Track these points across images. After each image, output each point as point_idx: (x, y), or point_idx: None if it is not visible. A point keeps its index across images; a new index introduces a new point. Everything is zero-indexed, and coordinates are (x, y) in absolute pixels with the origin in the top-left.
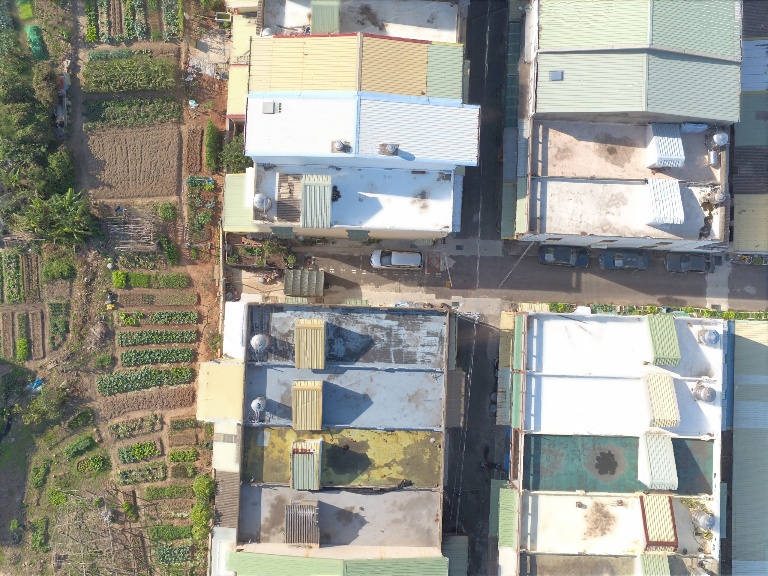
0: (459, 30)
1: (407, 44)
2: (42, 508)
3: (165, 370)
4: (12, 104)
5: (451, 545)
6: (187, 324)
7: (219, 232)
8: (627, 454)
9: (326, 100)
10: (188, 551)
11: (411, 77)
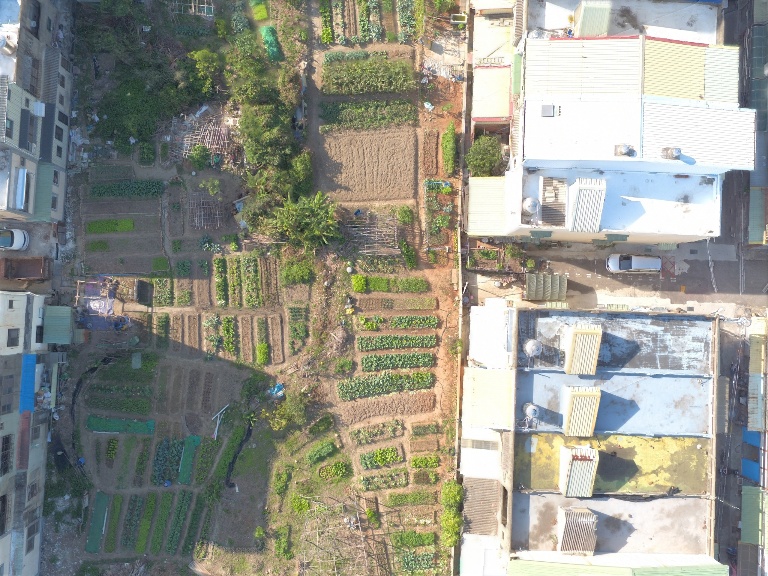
0: (723, 33)
1: (685, 47)
2: (284, 515)
3: (406, 375)
4: (258, 106)
5: None
6: (426, 329)
7: (457, 236)
8: None
9: (607, 103)
10: (432, 558)
11: (690, 80)
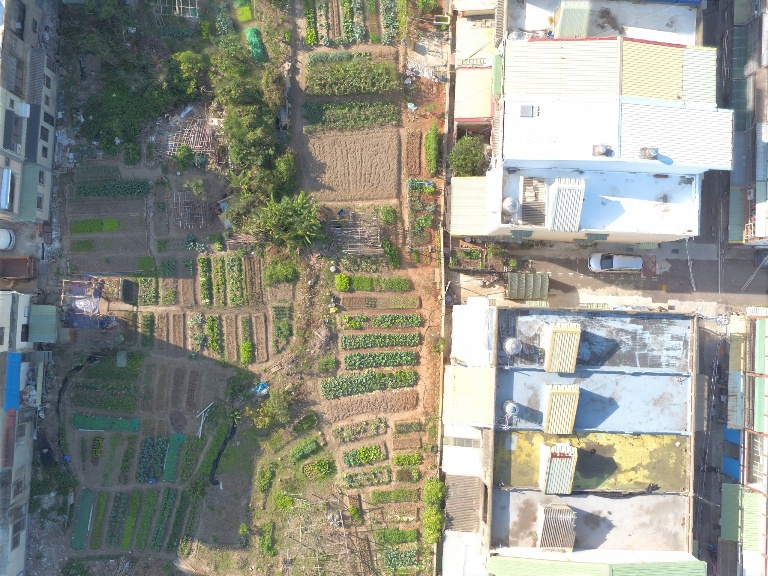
0: (702, 34)
1: (663, 48)
2: (268, 512)
3: (389, 373)
4: (242, 106)
5: None
6: (409, 327)
7: (439, 235)
8: None
9: (585, 104)
10: (414, 555)
11: (668, 81)
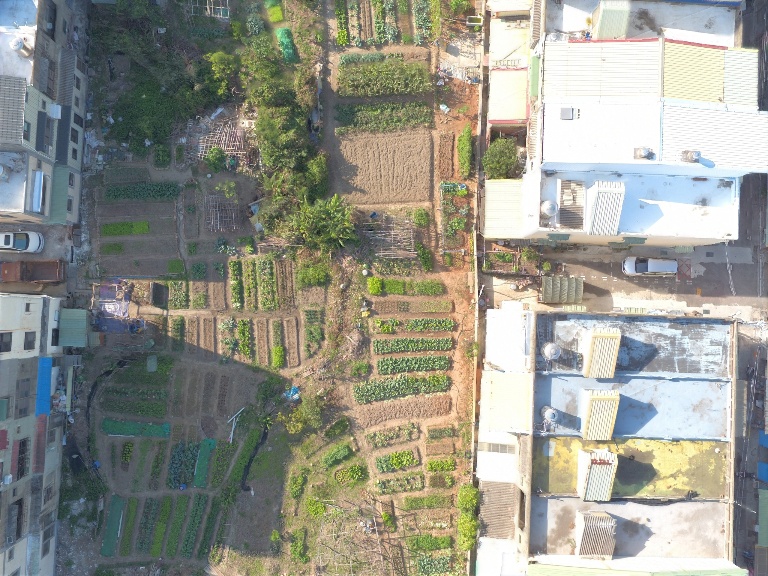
0: None
1: (704, 50)
2: (300, 518)
3: (422, 378)
4: (275, 108)
5: None
6: (442, 331)
7: (473, 238)
8: None
9: (626, 106)
10: (448, 562)
11: (709, 83)
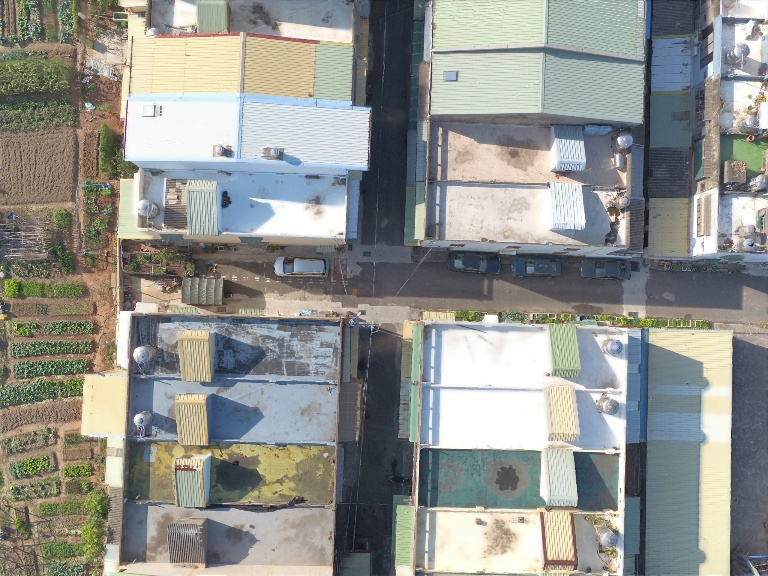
0: (353, 29)
1: (294, 44)
2: None
3: (59, 382)
4: None
5: (352, 563)
6: (83, 334)
7: (116, 239)
8: (529, 469)
9: (208, 103)
10: (82, 569)
11: (298, 78)
